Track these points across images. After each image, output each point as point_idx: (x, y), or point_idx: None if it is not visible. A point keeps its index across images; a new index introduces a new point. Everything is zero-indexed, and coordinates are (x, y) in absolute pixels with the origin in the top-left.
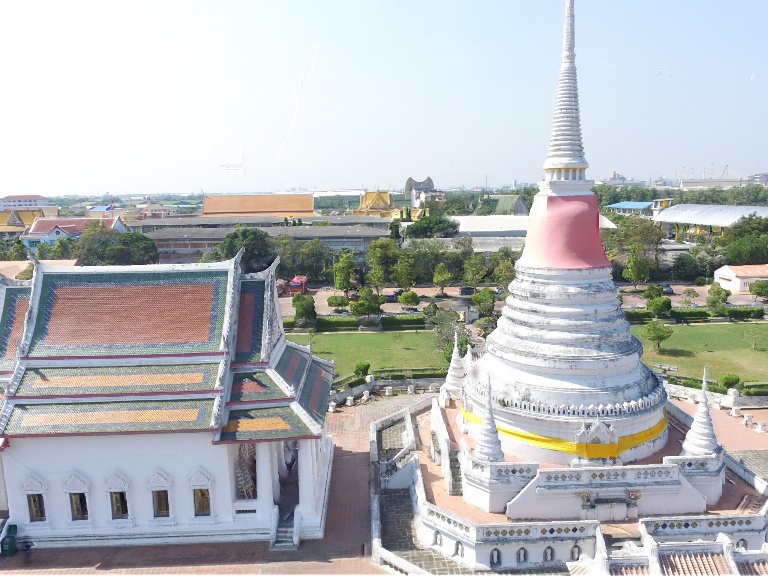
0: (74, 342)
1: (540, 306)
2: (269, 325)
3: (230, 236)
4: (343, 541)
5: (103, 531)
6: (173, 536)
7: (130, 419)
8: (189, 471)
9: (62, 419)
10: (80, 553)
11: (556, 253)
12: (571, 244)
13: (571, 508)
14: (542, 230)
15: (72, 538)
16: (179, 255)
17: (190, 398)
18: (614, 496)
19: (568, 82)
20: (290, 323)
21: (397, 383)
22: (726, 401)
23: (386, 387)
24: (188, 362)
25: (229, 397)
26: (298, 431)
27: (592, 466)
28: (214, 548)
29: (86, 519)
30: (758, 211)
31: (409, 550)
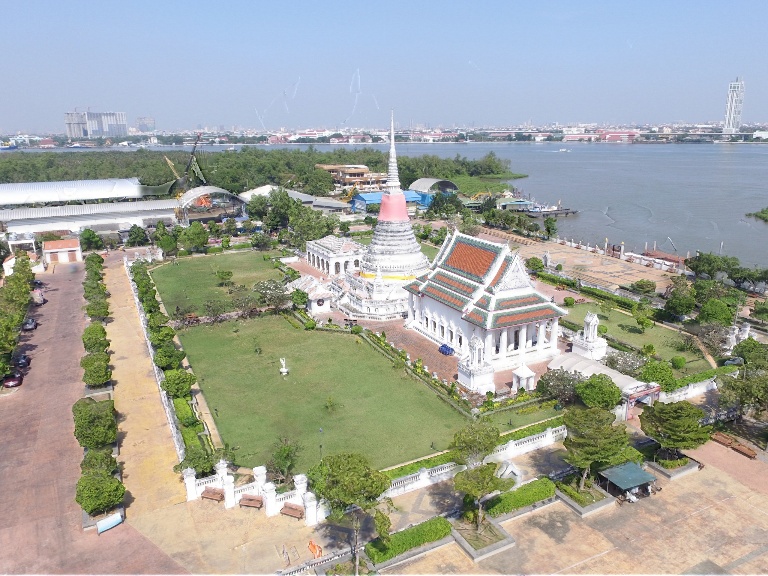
0: None
1: None
2: None
3: None
4: None
5: None
6: None
7: None
8: None
9: None
10: None
11: None
12: None
13: None
14: None
15: None
16: None
17: None
18: None
19: None
20: None
21: None
22: None
23: None
24: None
25: None
26: None
27: None
28: None
29: None
30: None
31: None
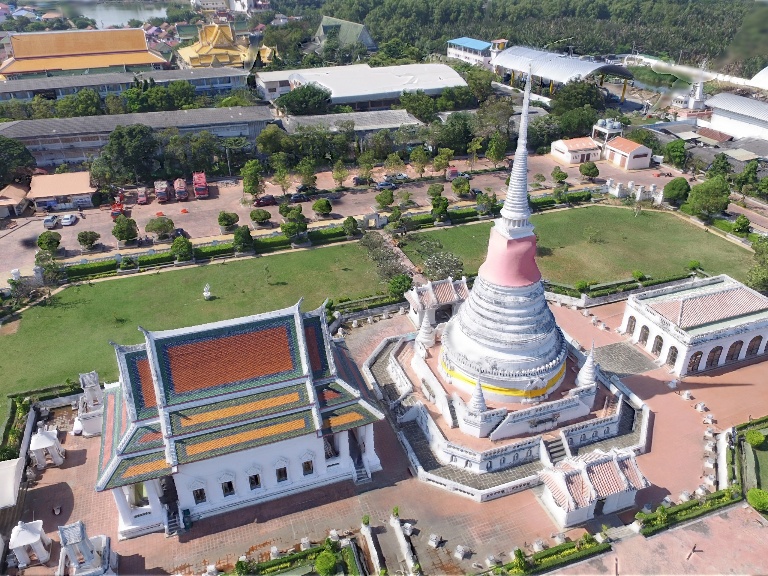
0: (197, 387)
1: (501, 309)
2: (331, 349)
3: (114, 136)
4: (395, 469)
5: (246, 498)
6: (291, 490)
7: (261, 435)
8: (300, 454)
9: (214, 445)
10: (237, 515)
11: (512, 276)
12: (521, 270)
13: (524, 428)
14: (503, 261)
15: (226, 506)
16: (50, 151)
17: (295, 412)
18: (546, 418)
19: (523, 162)
20: (230, 249)
21: (358, 314)
22: (580, 303)
23: (350, 319)
24: (284, 386)
25: (319, 405)
26: (369, 419)
27: (533, 402)
28: (321, 491)
29: (233, 494)
30: (580, 66)
31: (438, 468)
